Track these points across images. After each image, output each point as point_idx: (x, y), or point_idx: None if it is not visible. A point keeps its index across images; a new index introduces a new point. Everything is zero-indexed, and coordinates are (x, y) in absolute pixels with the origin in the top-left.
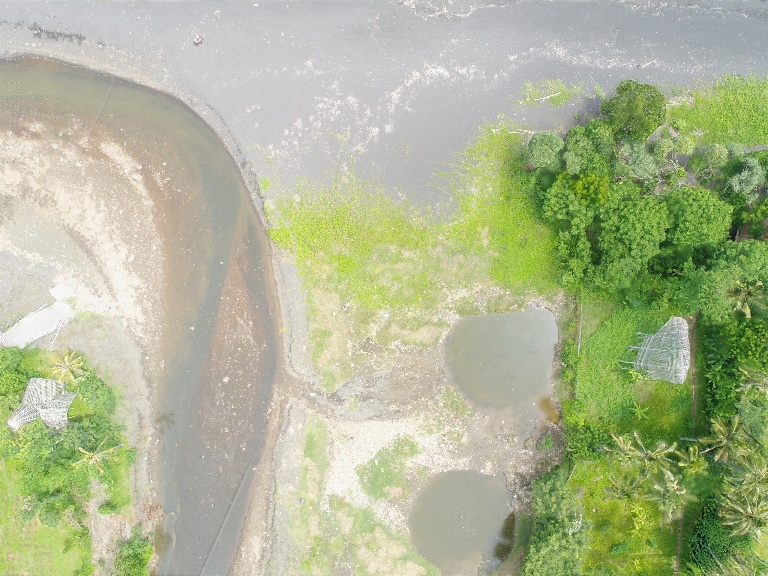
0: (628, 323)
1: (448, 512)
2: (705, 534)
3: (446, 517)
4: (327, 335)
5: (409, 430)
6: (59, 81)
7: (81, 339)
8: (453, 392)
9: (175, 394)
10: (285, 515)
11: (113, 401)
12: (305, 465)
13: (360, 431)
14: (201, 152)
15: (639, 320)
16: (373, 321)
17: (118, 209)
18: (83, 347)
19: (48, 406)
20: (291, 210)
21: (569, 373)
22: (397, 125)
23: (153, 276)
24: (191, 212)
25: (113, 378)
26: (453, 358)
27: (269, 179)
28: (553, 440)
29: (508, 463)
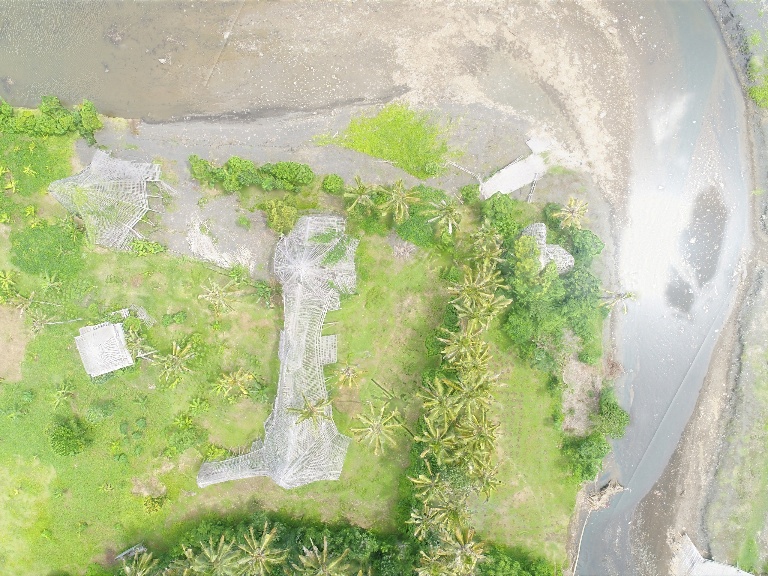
0: None
1: None
2: None
3: None
4: None
5: None
6: None
7: (560, 192)
8: None
9: (640, 253)
10: (752, 376)
11: (592, 255)
12: None
13: None
14: (679, 6)
15: None
16: None
17: (592, 63)
18: (562, 200)
19: None
20: None
21: None
22: None
23: (624, 133)
24: (666, 68)
25: None
26: None
27: (759, 34)
28: None
29: None
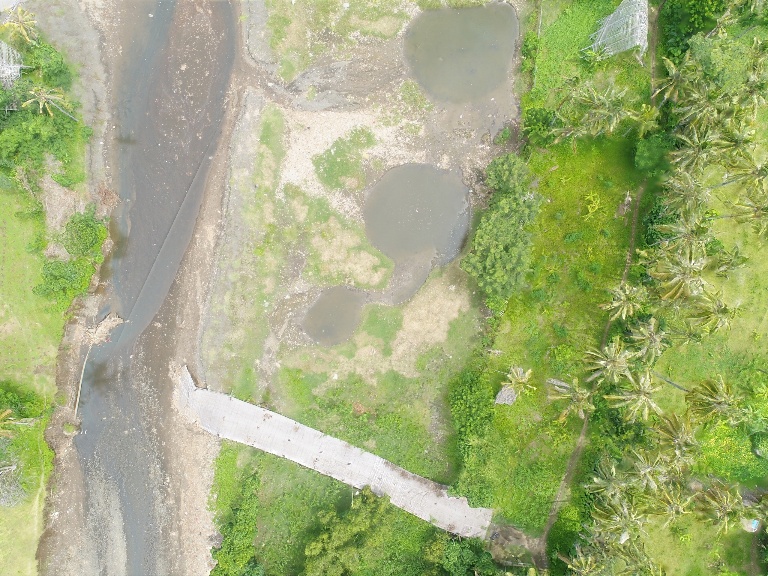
0: (589, 12)
1: (403, 205)
2: (657, 208)
3: (401, 210)
4: (286, 22)
5: (366, 122)
6: None
7: (38, 15)
8: (411, 85)
9: (132, 81)
10: (240, 200)
11: (69, 77)
12: (261, 152)
13: (317, 121)
14: None
15: (600, 10)
16: (332, 9)
17: None
18: (39, 23)
19: (1, 63)
20: None
21: (528, 60)
22: None
23: None
24: None
25: (69, 55)
26: (412, 51)
27: None
28: (511, 136)
29: (465, 158)
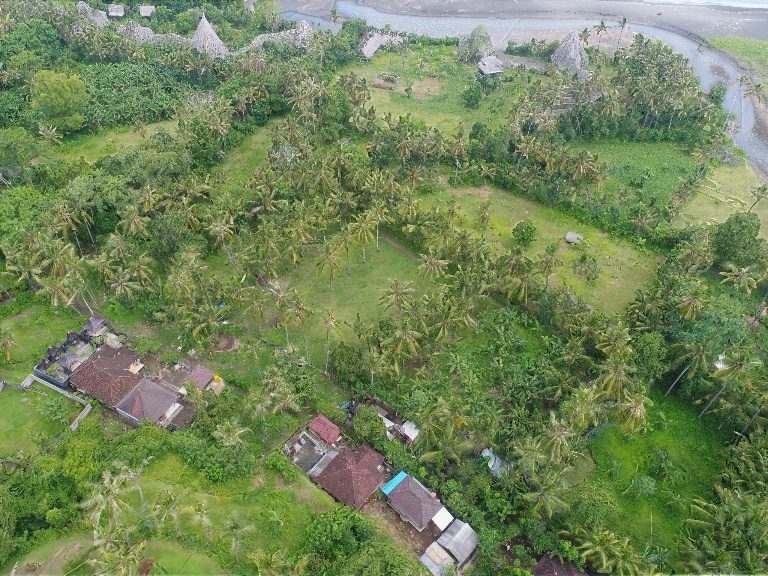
0: None
1: None
2: None
3: None
4: None
5: None
6: (609, 23)
7: None
8: None
9: None
10: None
11: None
12: (767, 86)
13: None
14: None
15: None
16: (766, 61)
17: None
18: None
19: None
20: (716, 40)
21: None
22: (742, 27)
23: None
24: None
25: None
26: None
27: None
28: None
29: None
